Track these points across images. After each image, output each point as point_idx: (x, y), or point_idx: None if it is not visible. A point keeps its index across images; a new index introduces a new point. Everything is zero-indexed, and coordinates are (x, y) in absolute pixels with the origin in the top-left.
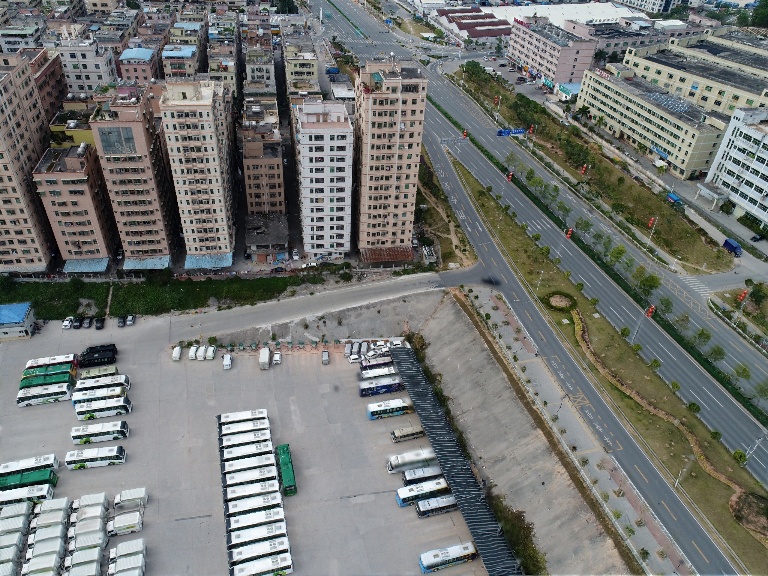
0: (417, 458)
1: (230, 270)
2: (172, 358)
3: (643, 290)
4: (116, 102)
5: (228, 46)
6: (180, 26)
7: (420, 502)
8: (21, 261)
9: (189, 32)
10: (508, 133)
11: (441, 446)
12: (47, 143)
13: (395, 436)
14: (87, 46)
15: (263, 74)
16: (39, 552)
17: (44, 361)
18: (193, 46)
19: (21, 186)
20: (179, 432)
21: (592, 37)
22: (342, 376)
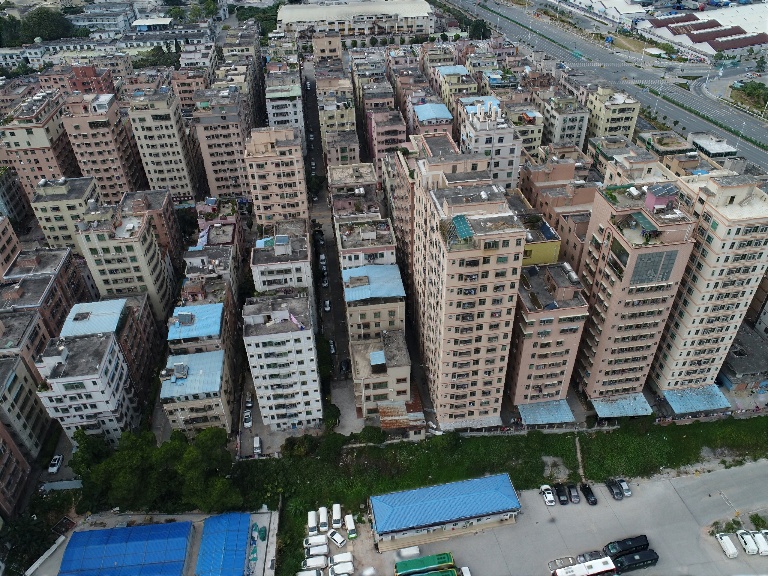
0: None
1: (726, 410)
2: (729, 555)
3: None
4: None
5: (524, 93)
6: (446, 71)
7: None
8: (473, 413)
9: (465, 78)
10: None
11: None
12: None
13: None
14: (508, 128)
15: (575, 124)
16: None
17: (582, 572)
18: (491, 97)
19: None
20: None
21: None
22: None
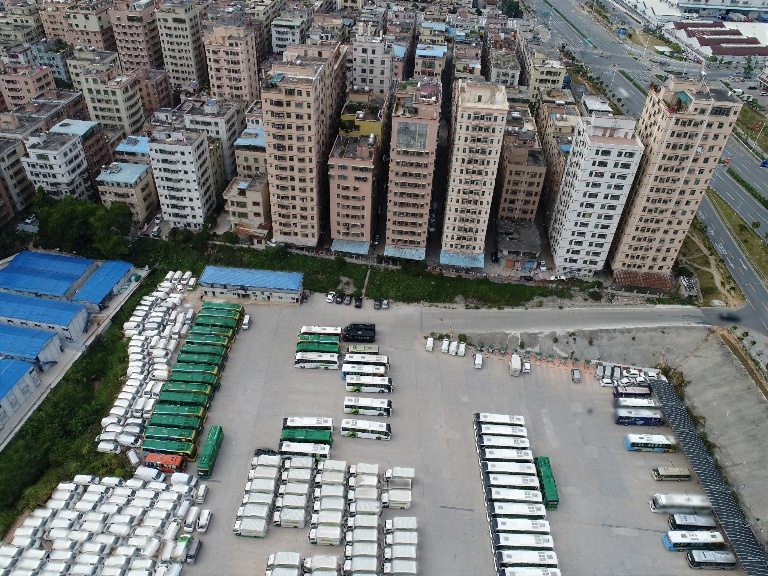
0: (682, 502)
1: (481, 271)
2: (426, 348)
3: None
4: (418, 99)
5: (476, 49)
6: (427, 26)
7: (694, 551)
8: (298, 234)
9: (437, 32)
10: None
11: (717, 497)
12: (332, 130)
13: (659, 474)
14: (379, 43)
15: (508, 79)
16: (326, 506)
17: (317, 329)
18: (444, 46)
19: (316, 167)
20: (437, 421)
21: None
22: (594, 398)
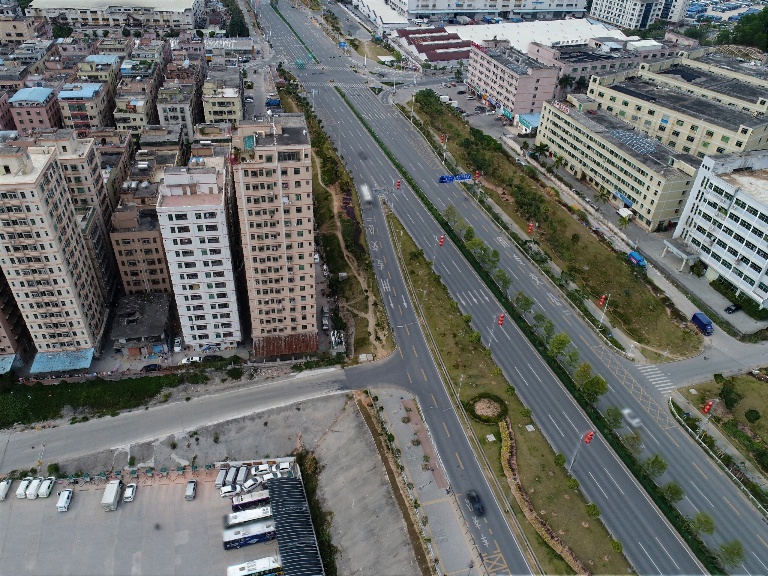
0: None
1: (89, 371)
2: None
3: (587, 395)
4: None
5: (140, 83)
6: (93, 59)
7: None
8: None
9: (100, 66)
10: (451, 179)
11: None
12: None
13: None
14: None
15: (177, 114)
16: None
17: None
18: (98, 84)
19: None
20: None
21: (557, 61)
22: (208, 518)
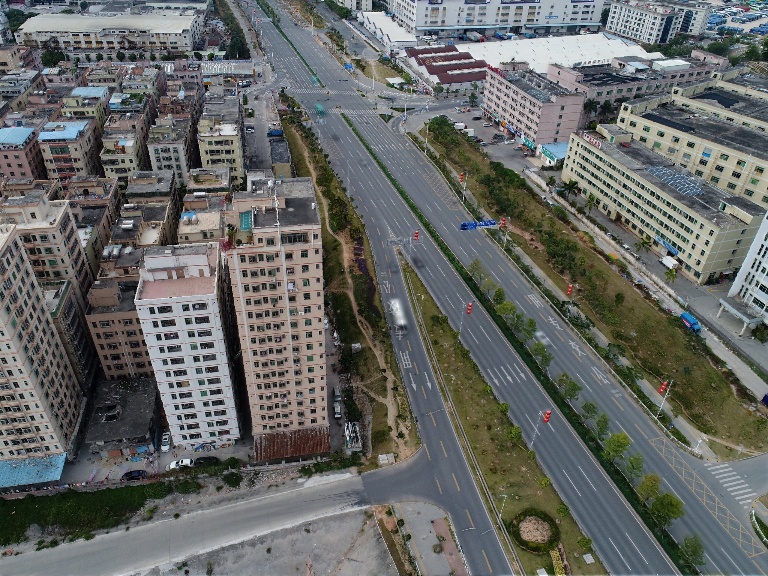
0: None
1: (59, 483)
2: None
3: (657, 517)
4: None
5: (129, 120)
6: (79, 92)
7: None
8: None
9: (87, 101)
10: (474, 226)
11: None
12: None
13: None
14: None
15: (170, 155)
16: None
17: None
18: (83, 122)
19: None
20: None
21: (580, 85)
22: None
